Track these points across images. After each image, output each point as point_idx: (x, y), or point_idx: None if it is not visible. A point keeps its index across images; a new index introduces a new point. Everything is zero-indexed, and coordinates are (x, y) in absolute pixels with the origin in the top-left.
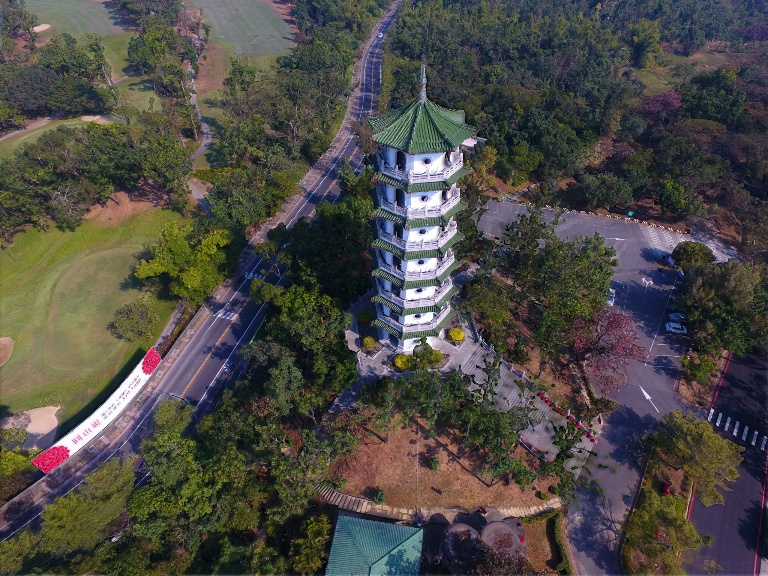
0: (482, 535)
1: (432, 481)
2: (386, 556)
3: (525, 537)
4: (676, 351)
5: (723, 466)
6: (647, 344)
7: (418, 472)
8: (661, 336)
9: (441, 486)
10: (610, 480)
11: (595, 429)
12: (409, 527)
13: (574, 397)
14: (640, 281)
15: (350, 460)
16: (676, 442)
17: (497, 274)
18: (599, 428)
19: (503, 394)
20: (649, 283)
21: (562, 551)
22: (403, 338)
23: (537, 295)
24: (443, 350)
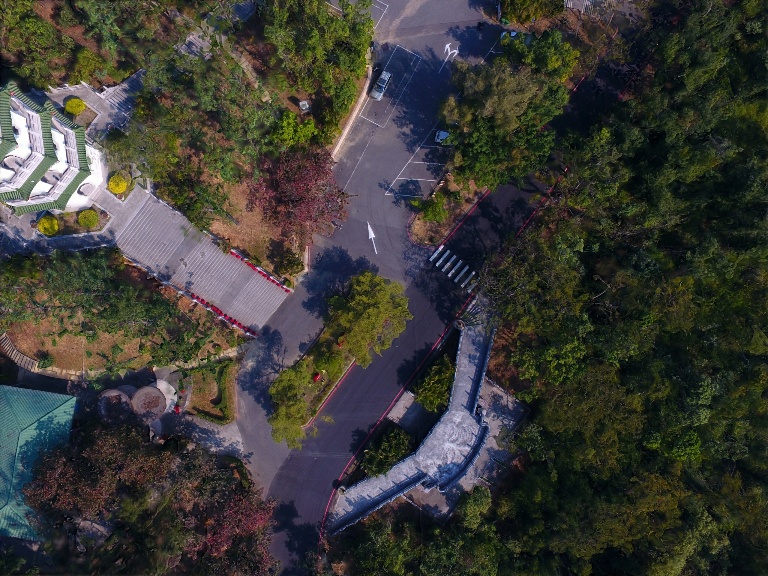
0: (133, 398)
1: (97, 348)
2: (35, 423)
3: (188, 387)
4: (432, 173)
5: (384, 333)
6: (401, 163)
7: (82, 340)
8: (424, 150)
9: (106, 351)
10: (293, 329)
11: (296, 276)
12: (63, 395)
13: (281, 242)
14: (440, 50)
15: (21, 323)
16: (340, 315)
17: (228, 46)
18: (301, 275)
19: (181, 254)
20: (452, 54)
21: (222, 395)
22: (18, 214)
23: (275, 88)
24: (104, 205)
